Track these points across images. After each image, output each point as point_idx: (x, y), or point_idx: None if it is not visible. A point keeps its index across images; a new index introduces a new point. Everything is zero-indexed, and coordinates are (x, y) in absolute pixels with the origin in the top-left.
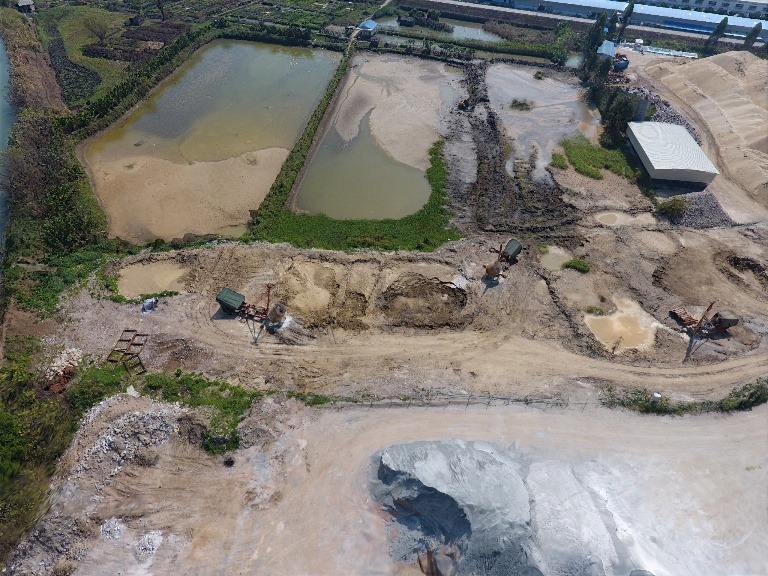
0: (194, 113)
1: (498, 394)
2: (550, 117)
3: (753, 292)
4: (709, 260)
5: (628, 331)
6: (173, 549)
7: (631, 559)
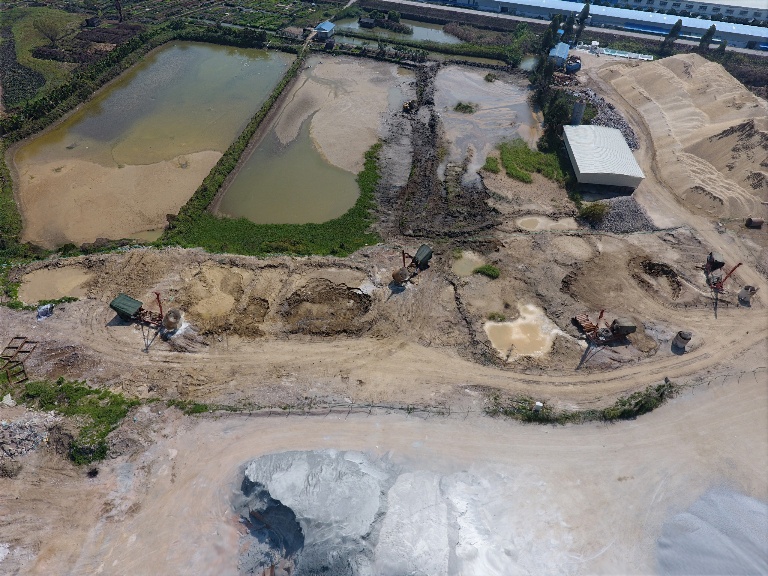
0: (134, 115)
1: (382, 402)
2: (492, 120)
3: (661, 298)
4: (623, 265)
5: (526, 338)
6: (17, 562)
7: (459, 574)
